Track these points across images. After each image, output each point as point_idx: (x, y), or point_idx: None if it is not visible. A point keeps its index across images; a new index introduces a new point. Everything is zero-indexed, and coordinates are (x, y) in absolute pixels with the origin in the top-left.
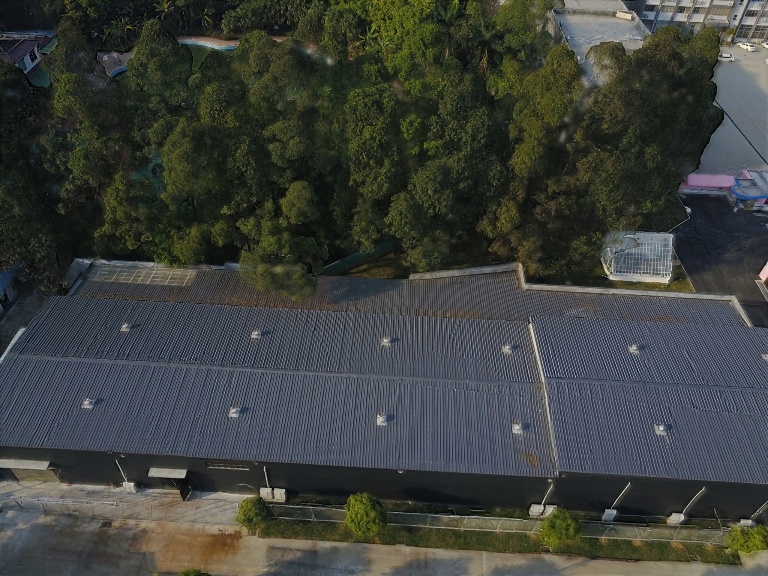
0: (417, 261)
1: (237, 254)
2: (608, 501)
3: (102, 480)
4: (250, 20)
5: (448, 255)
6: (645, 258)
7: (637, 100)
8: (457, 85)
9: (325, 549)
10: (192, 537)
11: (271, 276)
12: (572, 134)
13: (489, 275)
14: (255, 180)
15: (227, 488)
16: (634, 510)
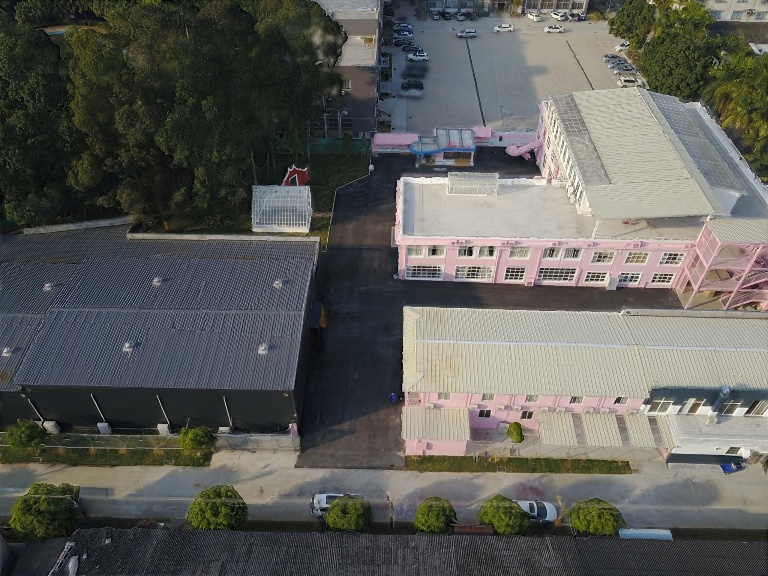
0: (10, 215)
1: None
2: (95, 415)
3: None
4: (40, 10)
5: (50, 209)
6: (282, 210)
7: (190, 57)
8: (12, 49)
9: None
10: None
11: None
12: None
13: (105, 228)
14: None
15: None
16: (127, 423)
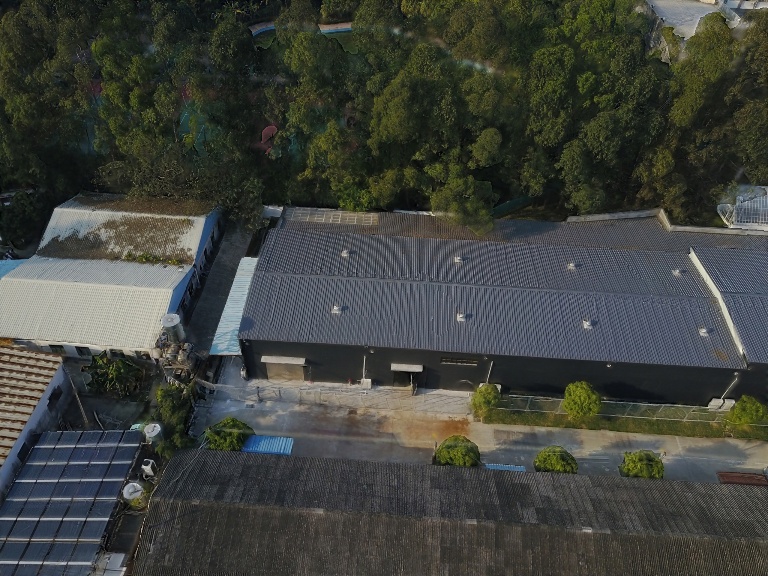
0: (581, 203)
1: (402, 203)
2: None
3: (341, 378)
4: (348, 5)
5: (604, 199)
6: (763, 209)
7: None
8: (627, 46)
9: (542, 432)
10: (428, 422)
11: (463, 212)
12: (726, 89)
13: (634, 219)
14: (448, 129)
15: (448, 385)
16: None
